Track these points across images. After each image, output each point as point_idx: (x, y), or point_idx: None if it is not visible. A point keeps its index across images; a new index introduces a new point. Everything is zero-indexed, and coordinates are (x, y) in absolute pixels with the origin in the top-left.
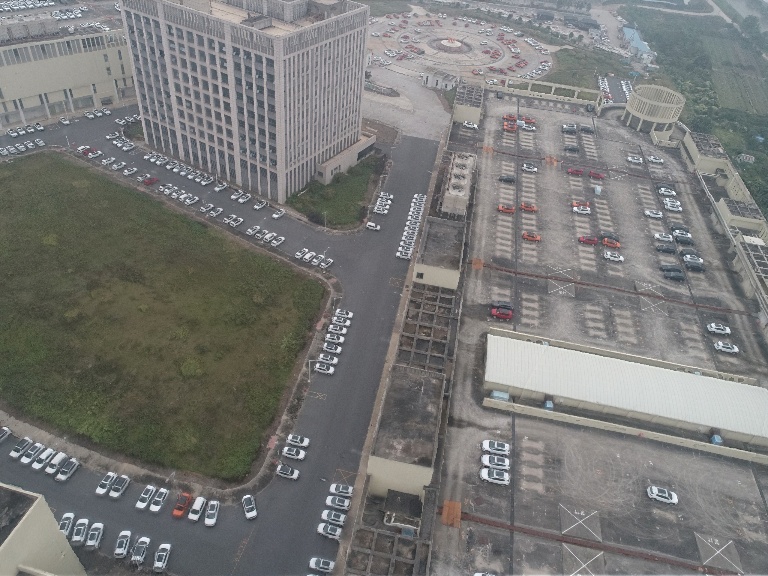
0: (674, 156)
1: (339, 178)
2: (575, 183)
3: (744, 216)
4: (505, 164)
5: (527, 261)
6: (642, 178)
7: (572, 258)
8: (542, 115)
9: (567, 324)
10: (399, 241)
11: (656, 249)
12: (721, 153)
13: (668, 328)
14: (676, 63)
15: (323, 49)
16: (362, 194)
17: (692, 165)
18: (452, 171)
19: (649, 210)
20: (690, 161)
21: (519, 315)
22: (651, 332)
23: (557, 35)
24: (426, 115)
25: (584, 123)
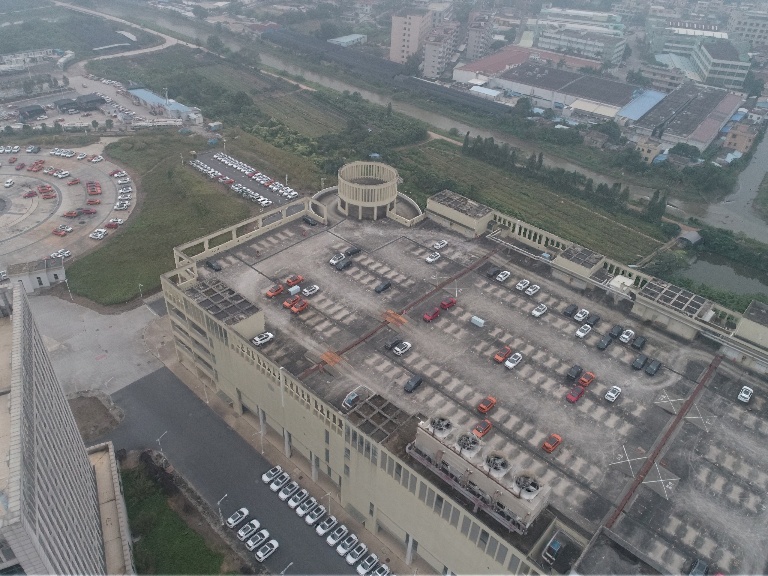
0: (438, 229)
1: (146, 562)
2: (451, 329)
3: (593, 263)
4: (373, 363)
5: (597, 480)
6: (465, 274)
7: (601, 430)
8: (289, 262)
9: (733, 522)
10: (348, 569)
11: (600, 349)
12: (479, 206)
13: (739, 431)
14: (222, 110)
15: (38, 428)
16: (206, 550)
17: (472, 231)
18: (467, 459)
19: (526, 308)
20: (467, 229)
21: (712, 565)
22: (748, 450)
23: (75, 130)
24: (91, 339)
25: (334, 243)
